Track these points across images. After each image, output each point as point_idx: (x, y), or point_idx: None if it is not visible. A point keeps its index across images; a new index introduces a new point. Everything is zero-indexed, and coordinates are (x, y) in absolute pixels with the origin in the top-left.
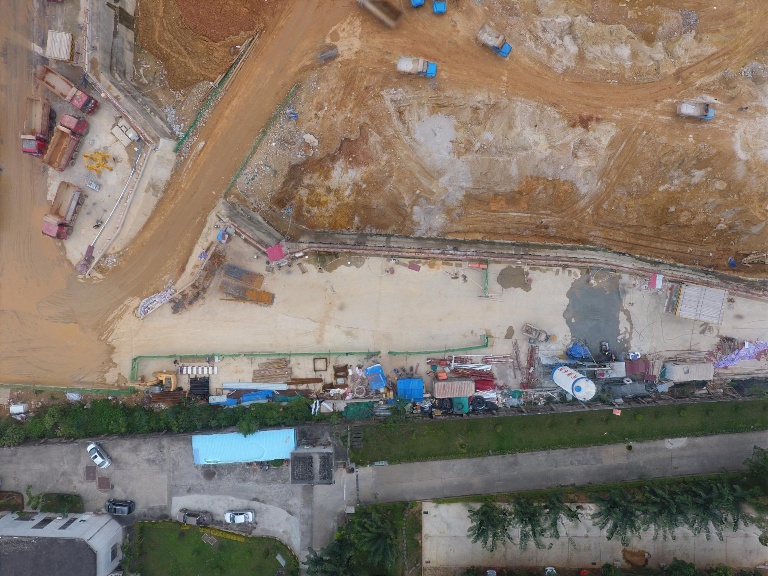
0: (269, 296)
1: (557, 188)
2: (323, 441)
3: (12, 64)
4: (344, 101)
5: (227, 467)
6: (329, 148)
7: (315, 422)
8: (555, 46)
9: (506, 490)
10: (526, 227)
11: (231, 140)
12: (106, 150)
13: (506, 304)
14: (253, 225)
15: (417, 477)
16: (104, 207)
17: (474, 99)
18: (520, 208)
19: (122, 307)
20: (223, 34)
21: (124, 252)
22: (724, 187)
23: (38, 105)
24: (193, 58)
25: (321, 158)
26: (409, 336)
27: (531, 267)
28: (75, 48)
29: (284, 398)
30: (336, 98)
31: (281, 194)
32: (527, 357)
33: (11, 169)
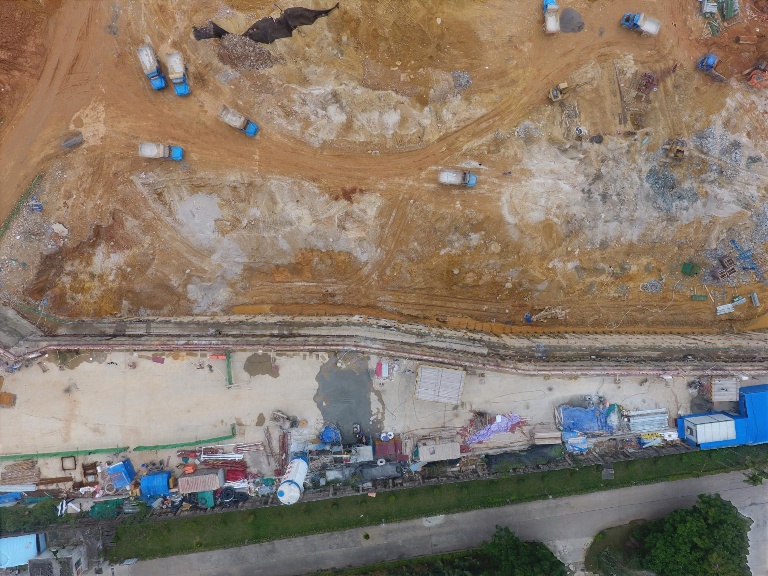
0: (10, 397)
1: (334, 258)
2: (75, 540)
3: None
4: (92, 188)
5: None
6: (79, 237)
7: (58, 525)
8: (316, 118)
9: None
10: (312, 296)
11: None
12: None
13: (255, 391)
14: None
15: (175, 570)
16: None
17: (227, 179)
18: (305, 278)
19: None
20: None
21: None
22: (498, 250)
23: None
24: None
25: (74, 246)
26: (158, 429)
27: (277, 353)
28: None
29: (34, 499)
30: (84, 185)
31: (39, 284)
32: (279, 444)
33: None
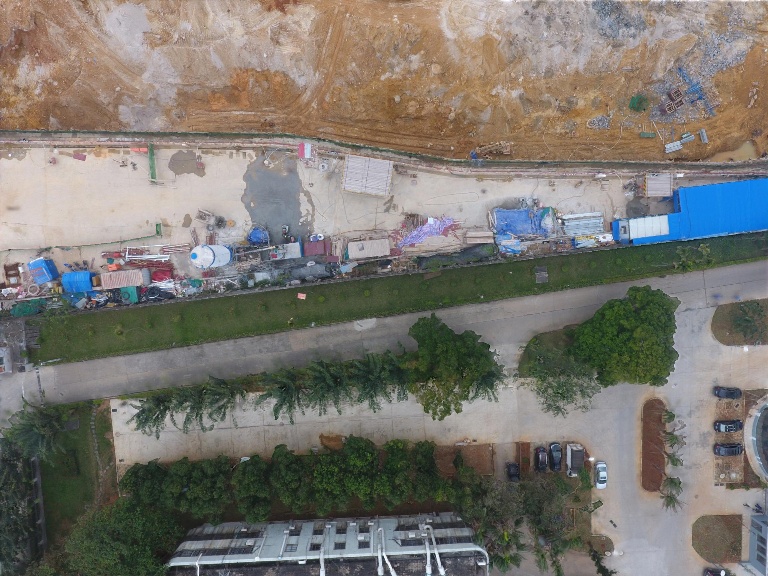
0: None
1: (270, 80)
2: None
3: None
4: None
5: None
6: None
7: None
8: None
9: (195, 382)
10: (251, 126)
11: None
12: None
13: (180, 191)
14: None
15: (101, 374)
16: None
17: None
18: (242, 106)
19: None
20: None
21: None
22: (438, 70)
23: None
24: None
25: None
26: (81, 229)
27: (203, 151)
28: None
29: None
30: None
31: None
32: None
33: None
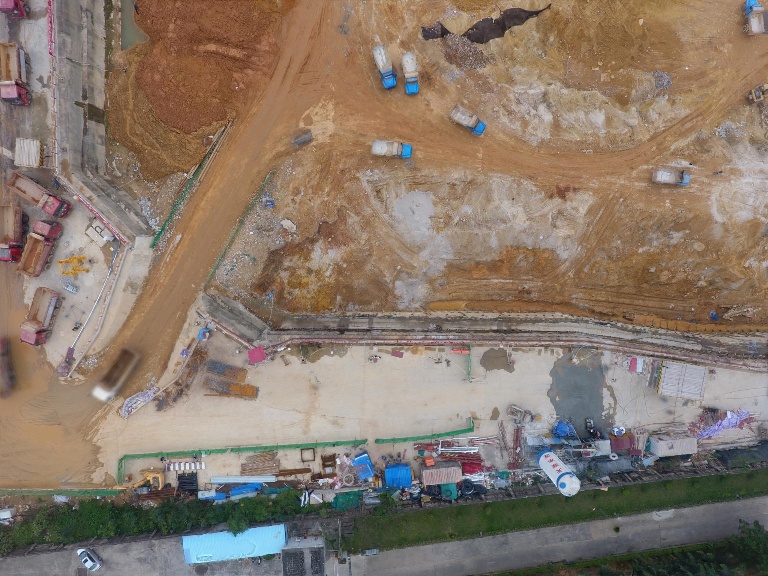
0: (253, 390)
1: (537, 256)
2: (314, 531)
3: None
4: (320, 185)
5: (219, 562)
6: (307, 233)
7: (305, 515)
8: (529, 117)
9: (498, 569)
10: (509, 293)
11: (208, 231)
12: (81, 251)
13: (490, 386)
14: (234, 318)
15: (409, 561)
16: (82, 309)
17: (450, 177)
18: (502, 275)
19: (106, 407)
20: (195, 125)
21: (105, 352)
22: (702, 249)
23: (10, 211)
24: (166, 150)
25: (300, 242)
26: (395, 422)
27: (513, 348)
28: (44, 152)
29: (273, 490)
30: (312, 182)
31: (261, 279)
32: (513, 437)
33: None
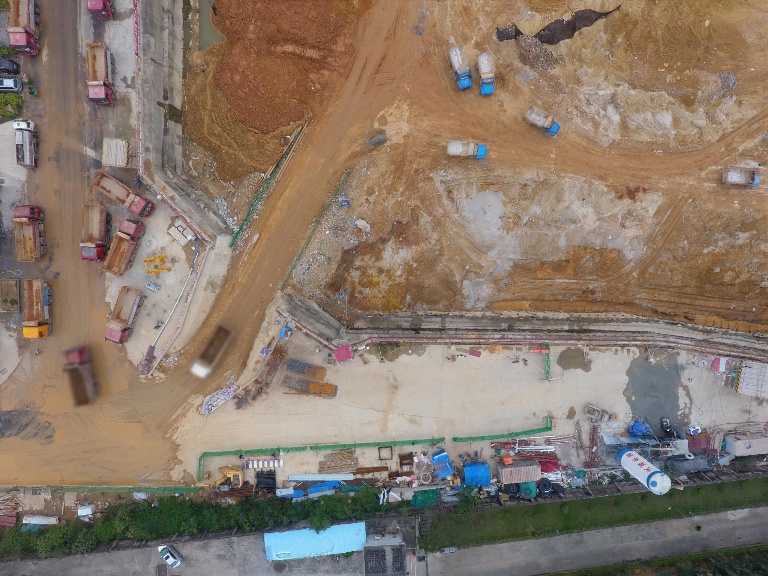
0: (332, 388)
1: (604, 256)
2: (391, 529)
3: (65, 168)
4: (394, 185)
5: (297, 559)
6: (381, 233)
7: (385, 513)
8: (599, 118)
9: (573, 568)
10: (573, 293)
11: (285, 231)
12: (163, 250)
13: (567, 385)
14: (312, 317)
15: (486, 559)
16: (164, 307)
17: (523, 177)
18: (566, 275)
19: (186, 405)
20: (273, 126)
21: (185, 350)
22: None
23: (94, 210)
24: (243, 150)
25: (373, 242)
26: (472, 421)
27: (590, 348)
28: (129, 152)
29: (351, 488)
30: (386, 182)
31: (334, 278)
32: (589, 437)
33: (68, 273)
